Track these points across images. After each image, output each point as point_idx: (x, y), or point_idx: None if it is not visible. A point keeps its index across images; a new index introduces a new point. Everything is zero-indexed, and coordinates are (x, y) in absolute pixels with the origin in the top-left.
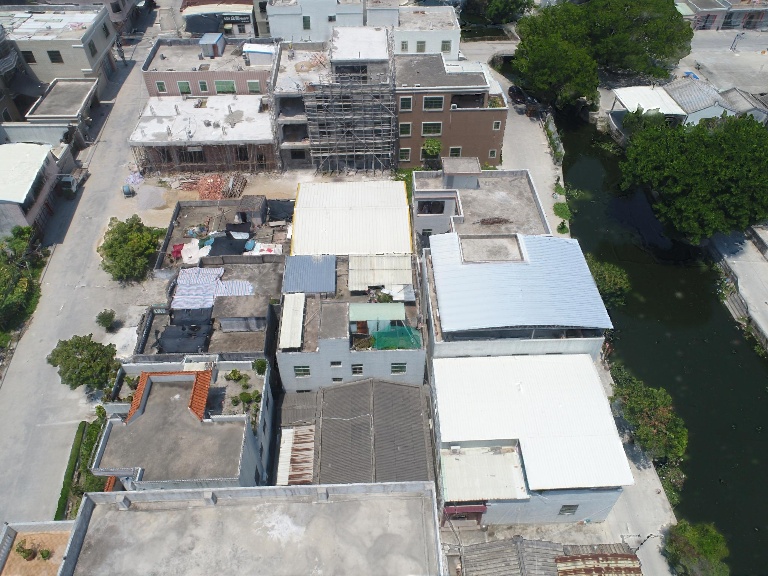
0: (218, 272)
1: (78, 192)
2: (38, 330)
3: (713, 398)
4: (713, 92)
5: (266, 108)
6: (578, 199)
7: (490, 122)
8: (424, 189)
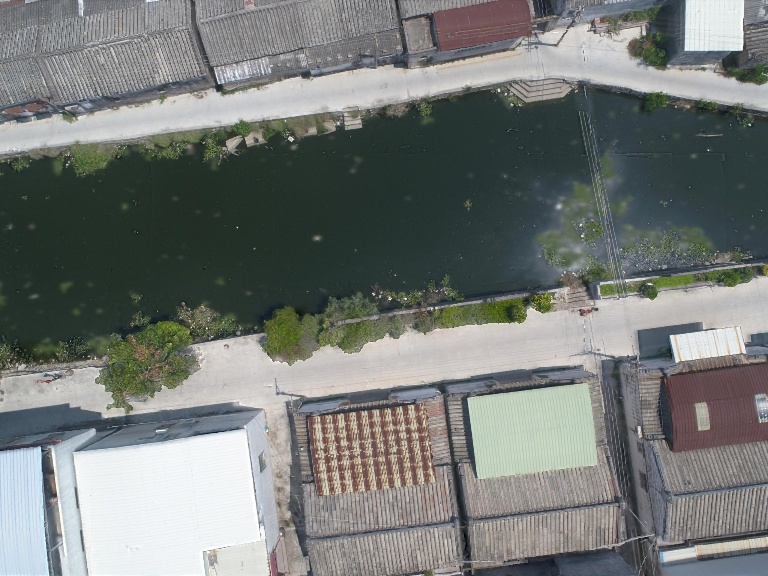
0: None
1: None
2: None
3: (98, 243)
4: None
5: None
6: None
7: None
8: None
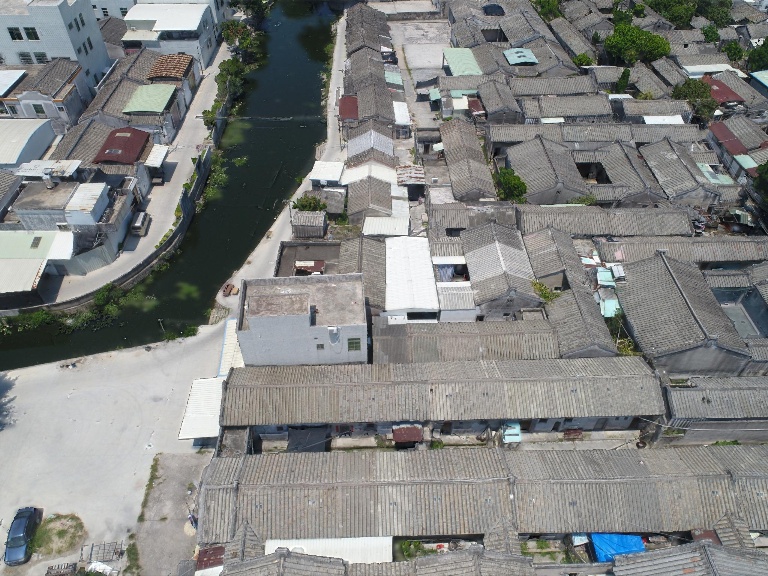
0: None
1: None
2: None
3: None
4: None
5: None
6: None
7: None
8: None
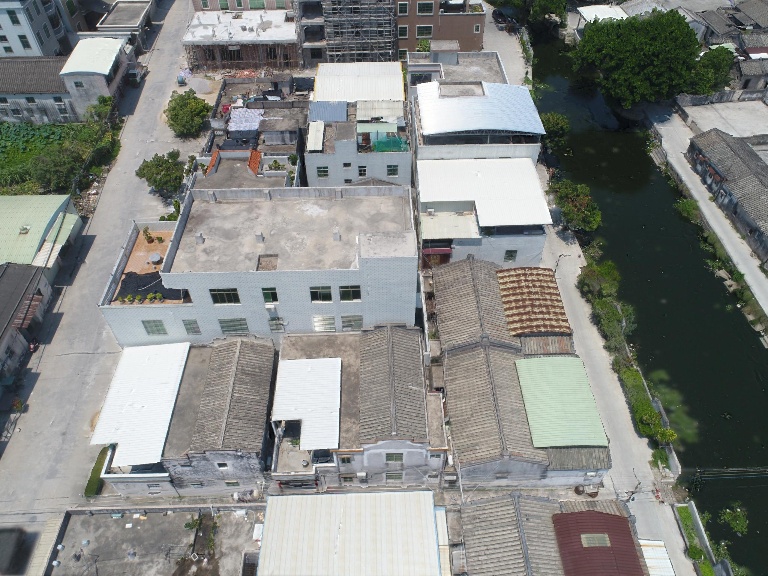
0: (260, 112)
1: (141, 83)
2: (122, 166)
3: (631, 211)
4: None
5: (290, 21)
6: (543, 89)
7: (471, 25)
8: (415, 63)
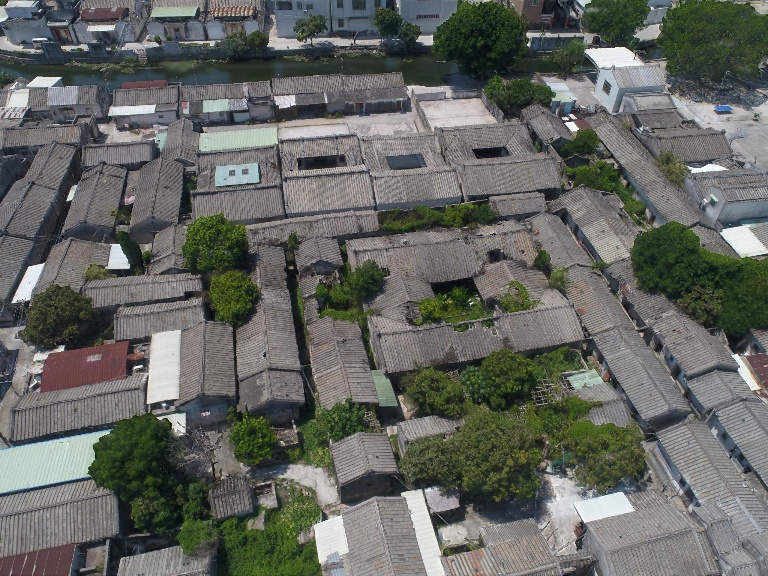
0: None
1: None
2: None
3: None
4: (648, 81)
5: None
6: None
7: None
8: None
